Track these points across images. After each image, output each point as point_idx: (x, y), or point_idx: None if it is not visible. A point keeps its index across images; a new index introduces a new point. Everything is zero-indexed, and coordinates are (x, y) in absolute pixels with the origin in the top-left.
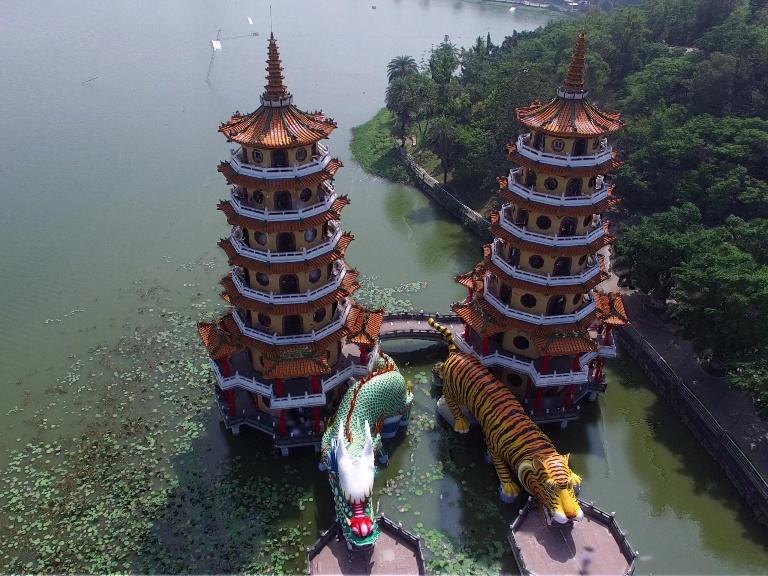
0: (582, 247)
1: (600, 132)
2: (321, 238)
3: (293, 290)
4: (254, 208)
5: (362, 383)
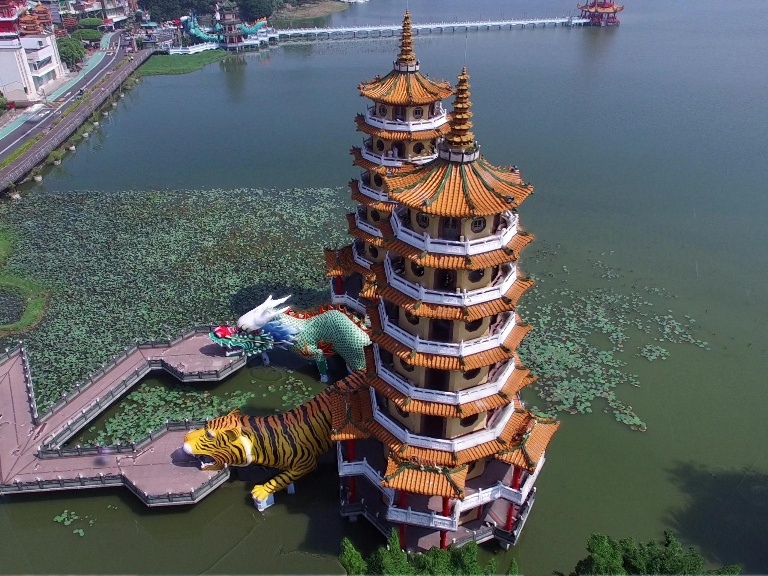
0: None
1: None
2: (386, 190)
3: None
4: None
5: None
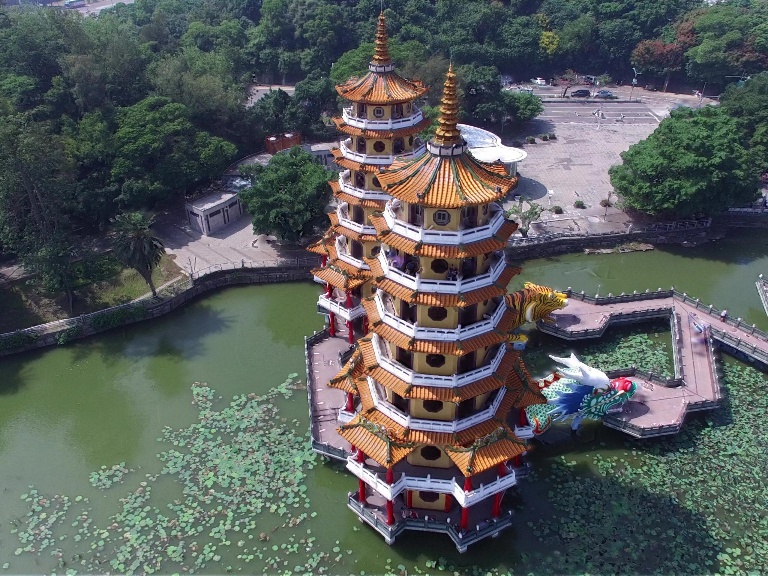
0: None
1: None
2: None
3: None
4: (498, 263)
5: None
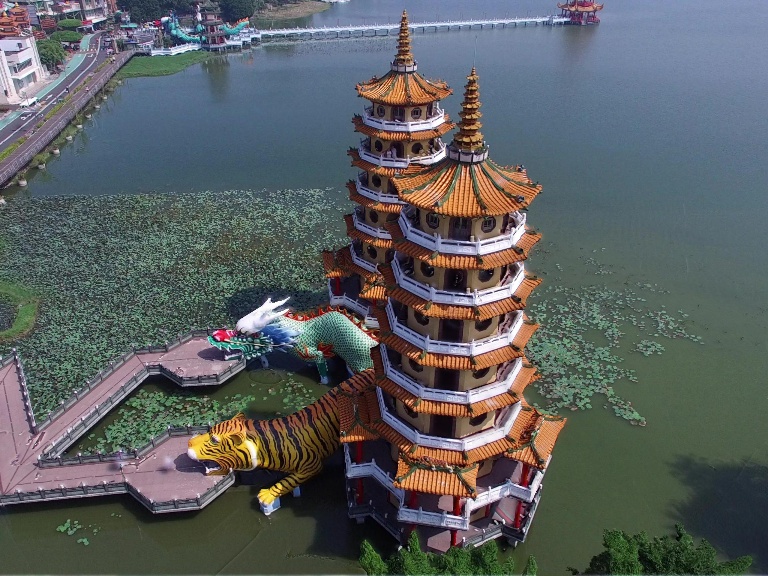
0: None
1: None
2: (385, 190)
3: None
4: None
5: None
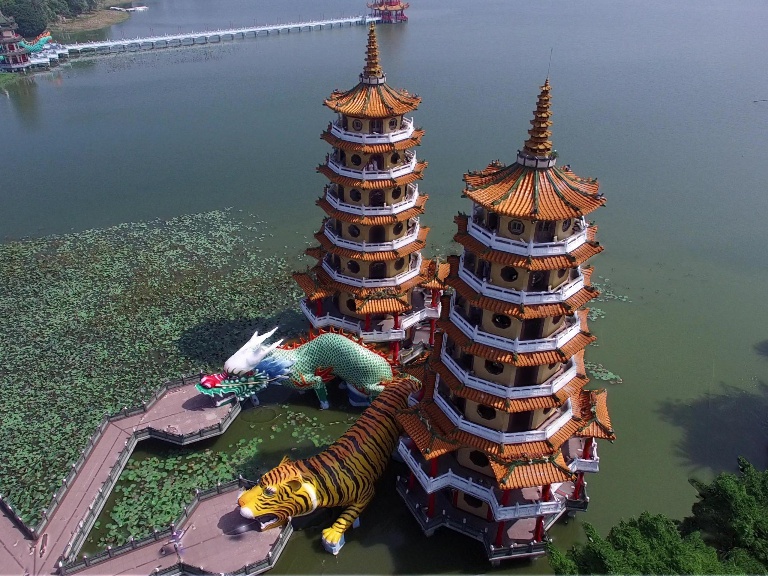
0: (467, 338)
1: (486, 204)
2: (366, 203)
3: (340, 232)
4: None
5: (331, 331)
